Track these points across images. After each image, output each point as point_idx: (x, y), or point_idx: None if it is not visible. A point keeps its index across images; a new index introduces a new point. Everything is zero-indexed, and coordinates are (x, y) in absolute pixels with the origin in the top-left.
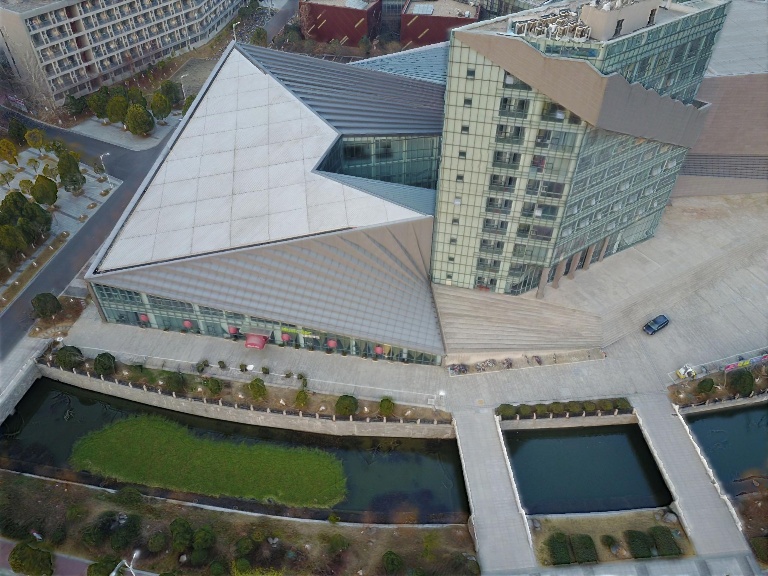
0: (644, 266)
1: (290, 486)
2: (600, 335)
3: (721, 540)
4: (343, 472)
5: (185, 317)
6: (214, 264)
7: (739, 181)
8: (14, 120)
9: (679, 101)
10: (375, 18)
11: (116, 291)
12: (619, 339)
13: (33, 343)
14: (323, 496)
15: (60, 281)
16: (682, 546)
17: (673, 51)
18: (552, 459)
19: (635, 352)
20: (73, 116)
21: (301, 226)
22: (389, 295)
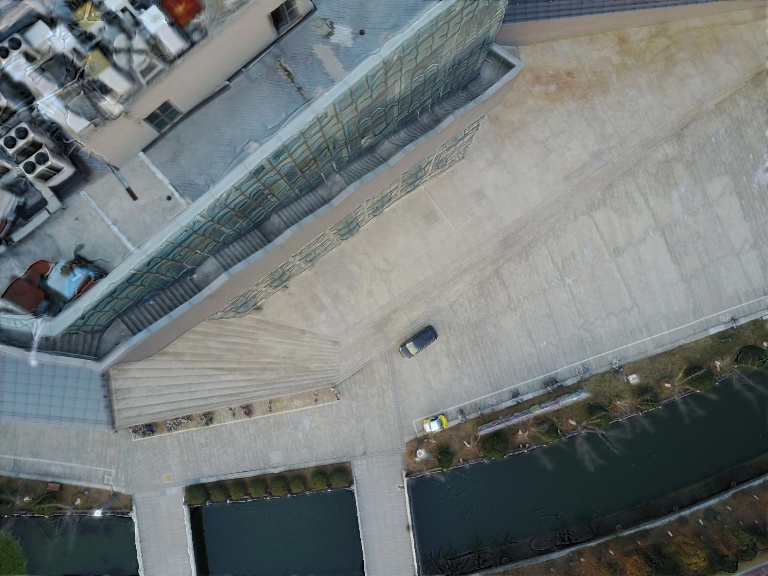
0: (429, 231)
1: None
2: (336, 367)
3: None
4: (22, 555)
5: None
6: None
7: (651, 12)
8: None
9: (403, 156)
10: None
11: None
12: (364, 366)
13: None
14: None
15: None
16: None
17: (341, 130)
18: (253, 536)
19: (380, 388)
20: None
21: None
22: None
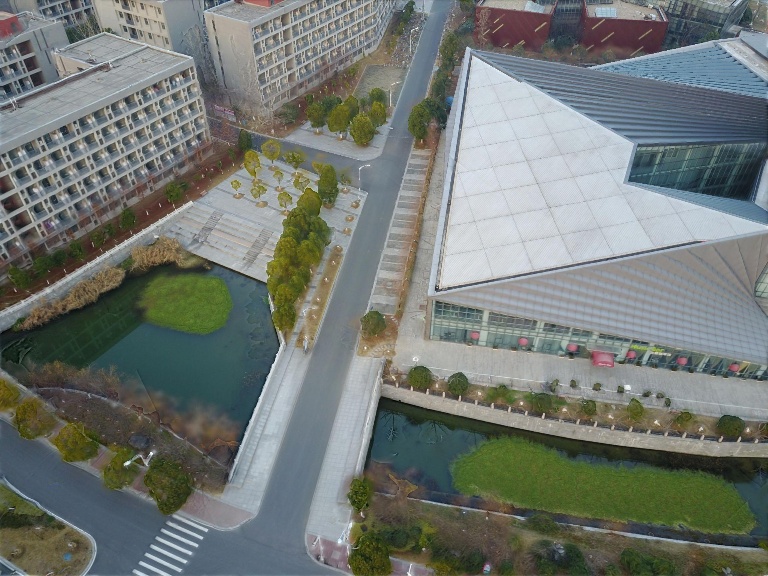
0: None
1: (695, 511)
2: None
3: None
4: (741, 495)
5: (522, 334)
6: (558, 280)
7: None
8: (244, 131)
9: None
10: (555, 22)
11: (457, 309)
12: None
13: (367, 362)
14: (735, 521)
15: (360, 297)
16: None
17: None
18: None
19: None
20: (285, 125)
21: (642, 240)
22: (731, 310)
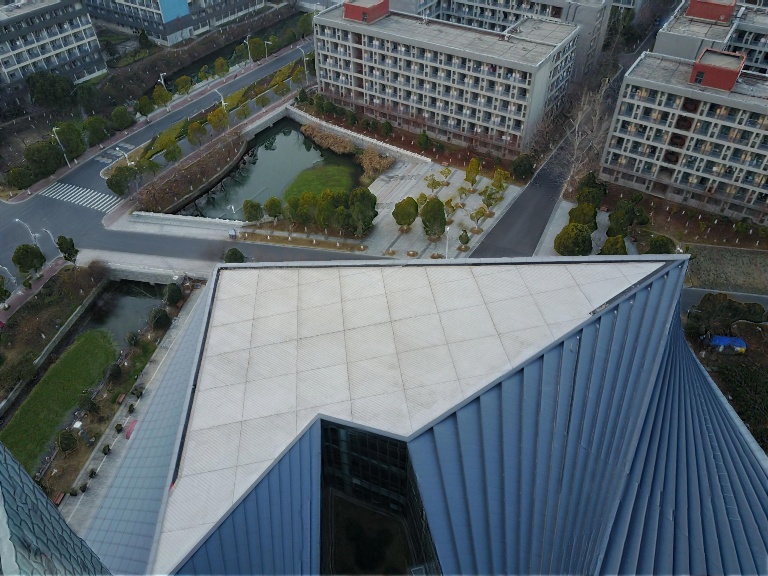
0: None
1: None
2: None
3: None
4: None
5: None
6: None
7: None
8: (524, 156)
9: None
10: None
11: None
12: None
13: (210, 270)
14: None
15: None
16: None
17: None
18: None
19: None
20: None
21: (207, 420)
22: None
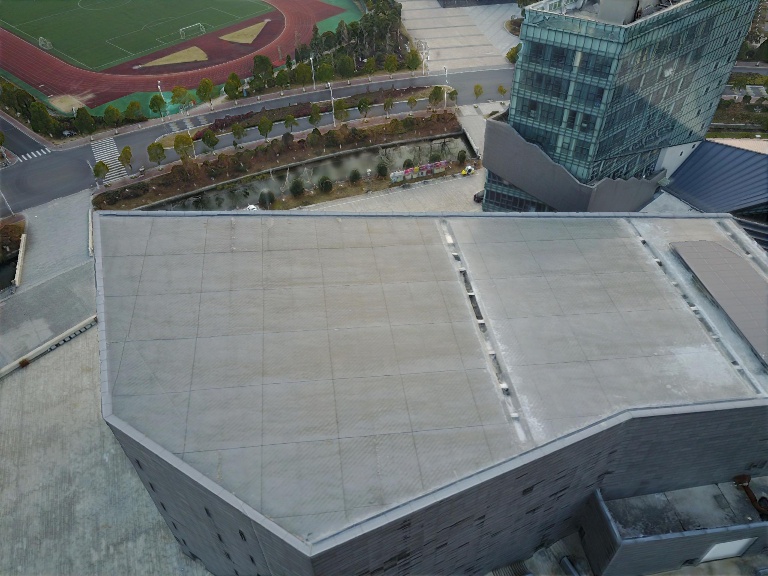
0: None
1: None
2: None
3: None
4: None
5: None
6: None
7: None
8: None
9: None
10: None
11: None
12: None
13: None
14: None
15: None
16: None
17: None
18: None
19: None
20: None
21: None
22: None
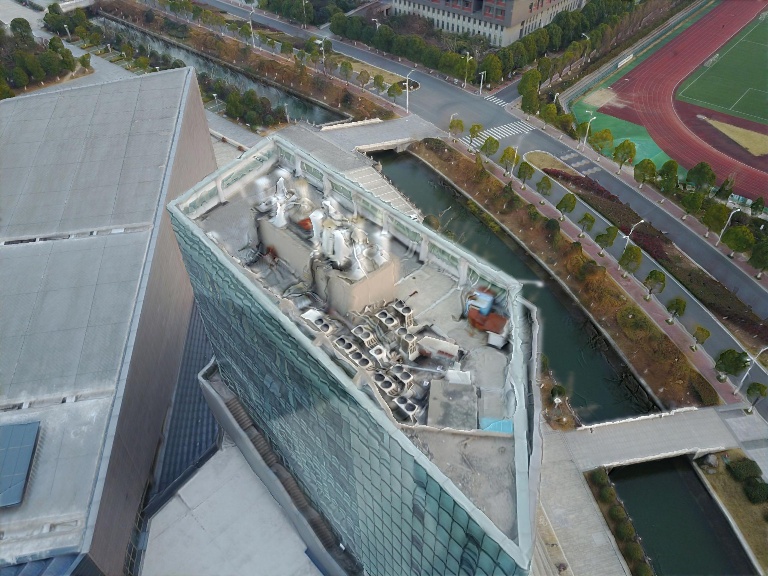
0: None
1: None
2: None
3: (716, 425)
4: None
5: None
6: None
7: None
8: None
9: None
10: None
11: None
12: None
13: None
14: None
15: None
16: (739, 456)
17: None
18: (686, 568)
19: None
20: None
21: None
22: None
